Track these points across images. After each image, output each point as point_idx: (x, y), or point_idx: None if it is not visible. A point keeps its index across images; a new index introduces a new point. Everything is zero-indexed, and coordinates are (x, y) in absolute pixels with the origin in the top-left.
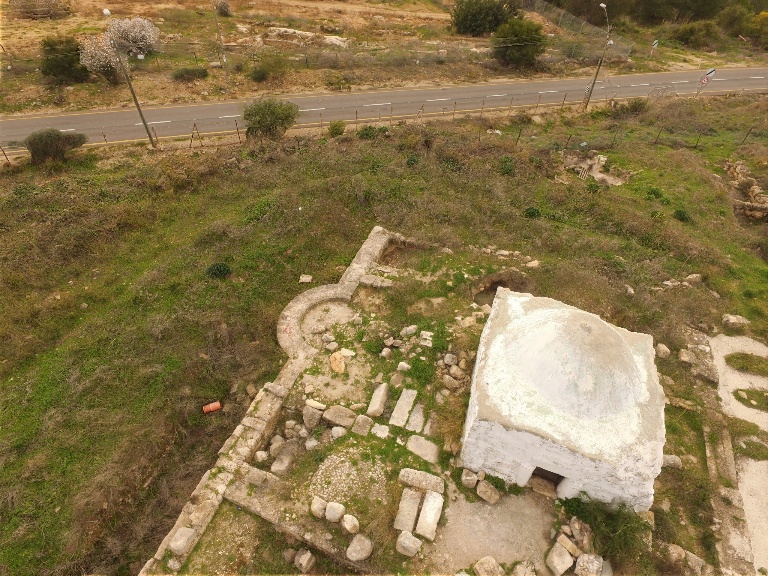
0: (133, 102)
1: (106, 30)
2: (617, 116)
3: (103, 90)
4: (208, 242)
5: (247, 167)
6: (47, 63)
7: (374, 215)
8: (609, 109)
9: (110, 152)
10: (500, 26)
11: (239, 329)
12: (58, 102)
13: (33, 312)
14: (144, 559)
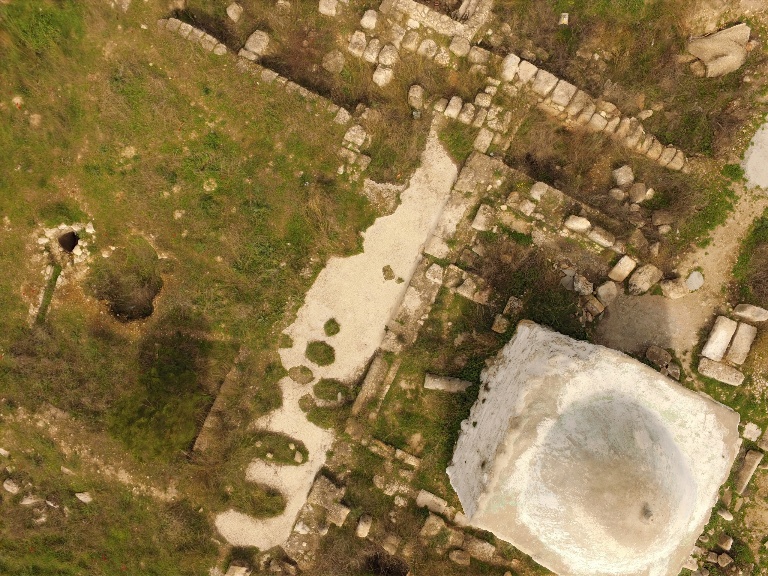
0: None
1: None
2: None
3: None
4: None
5: None
6: None
7: None
8: None
9: None
10: None
11: None
12: None
13: None
14: None
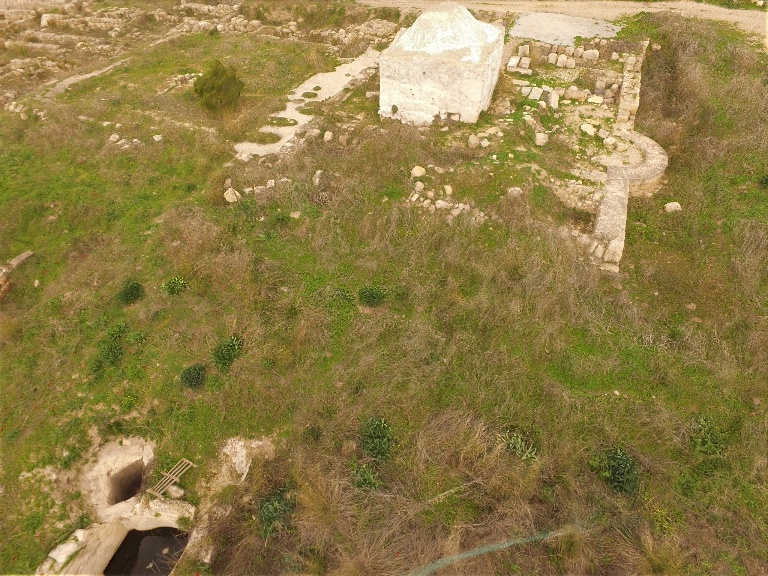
0: None
1: None
2: None
3: None
4: None
5: None
6: None
7: None
8: None
9: None
10: None
11: None
12: None
13: None
14: None
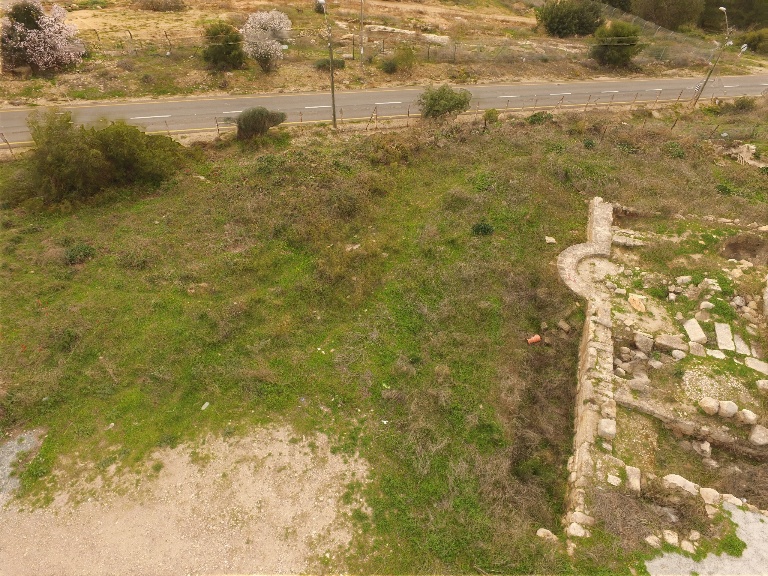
0: (287, 88)
1: (247, 21)
2: (738, 112)
3: (258, 76)
4: (456, 206)
5: (446, 145)
6: (212, 50)
7: (577, 189)
8: (717, 106)
9: (299, 131)
10: (599, 28)
11: (527, 277)
12: (223, 86)
13: (352, 258)
14: (561, 448)
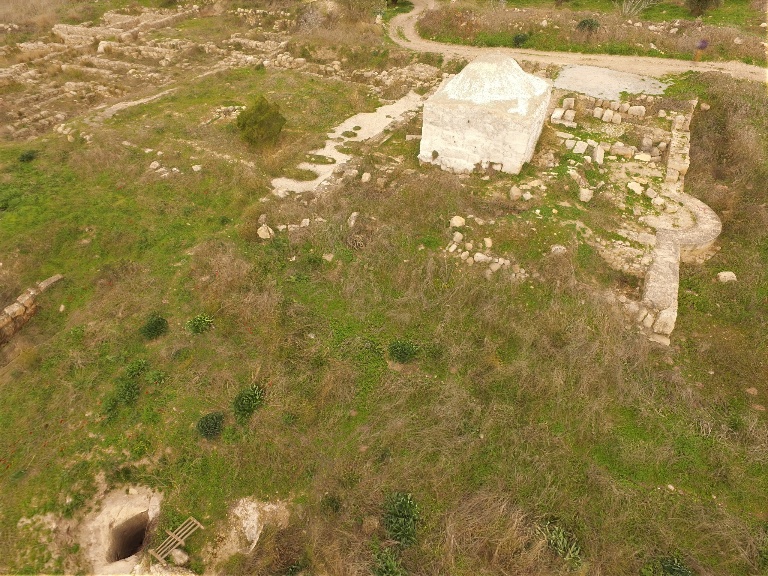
0: None
1: None
2: None
3: None
4: None
5: None
6: None
7: None
8: None
9: None
10: None
11: None
12: None
13: None
14: None
